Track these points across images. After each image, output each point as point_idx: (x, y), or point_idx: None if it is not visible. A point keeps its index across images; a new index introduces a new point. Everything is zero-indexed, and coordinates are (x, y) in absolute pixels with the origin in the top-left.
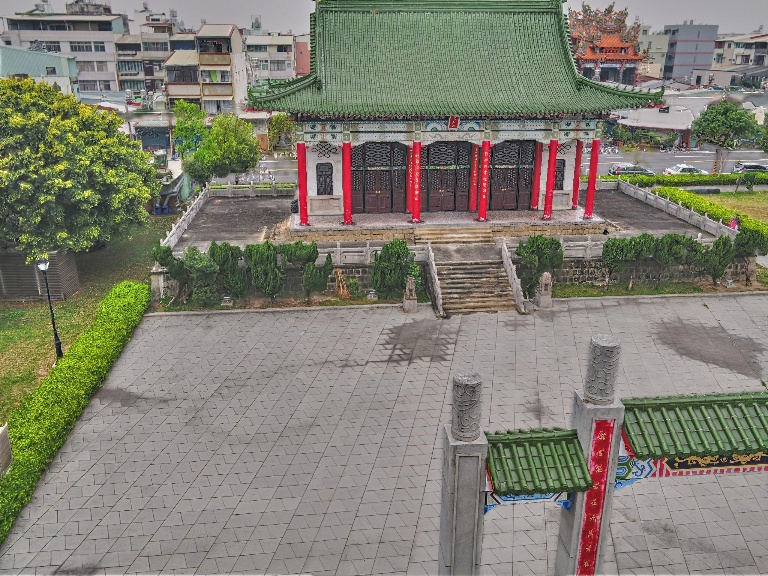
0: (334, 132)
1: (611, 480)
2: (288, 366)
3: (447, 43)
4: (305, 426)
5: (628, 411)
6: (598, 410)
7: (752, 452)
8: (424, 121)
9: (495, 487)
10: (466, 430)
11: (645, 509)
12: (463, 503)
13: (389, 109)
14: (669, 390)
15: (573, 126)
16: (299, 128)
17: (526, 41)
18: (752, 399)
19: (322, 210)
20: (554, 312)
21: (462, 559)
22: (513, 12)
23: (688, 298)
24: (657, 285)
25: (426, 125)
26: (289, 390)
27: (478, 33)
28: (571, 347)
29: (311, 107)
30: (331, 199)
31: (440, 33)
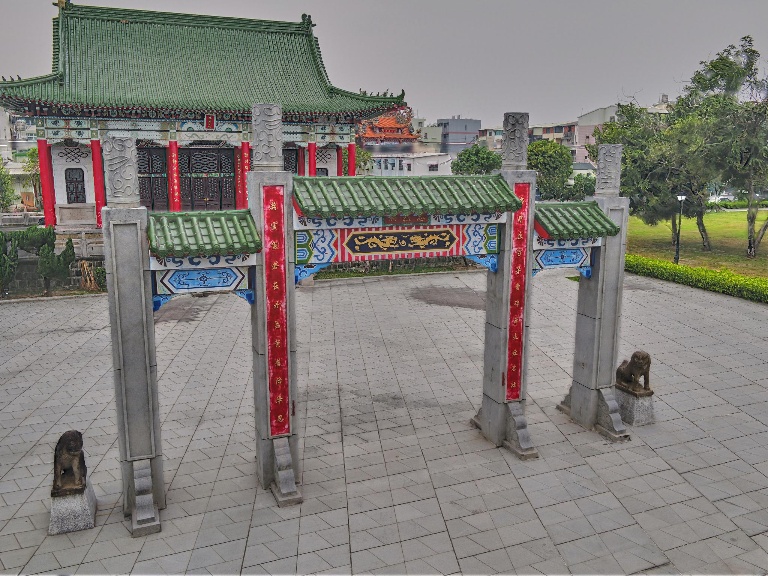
0: (80, 129)
1: (290, 259)
2: (7, 336)
3: (202, 54)
4: (13, 372)
5: (299, 184)
6: (264, 174)
7: (417, 212)
8: (179, 120)
9: (152, 246)
10: (119, 194)
11: (377, 388)
12: (126, 286)
13: (138, 103)
14: (415, 322)
15: (328, 130)
16: (39, 123)
17: (280, 57)
18: (419, 178)
19: (74, 220)
20: (315, 288)
21: (133, 360)
22: (266, 31)
23: (442, 274)
24: (415, 267)
25: (181, 124)
26: (2, 350)
27: (233, 47)
28: (327, 305)
29: (50, 98)
30: (84, 207)
31: (194, 45)
